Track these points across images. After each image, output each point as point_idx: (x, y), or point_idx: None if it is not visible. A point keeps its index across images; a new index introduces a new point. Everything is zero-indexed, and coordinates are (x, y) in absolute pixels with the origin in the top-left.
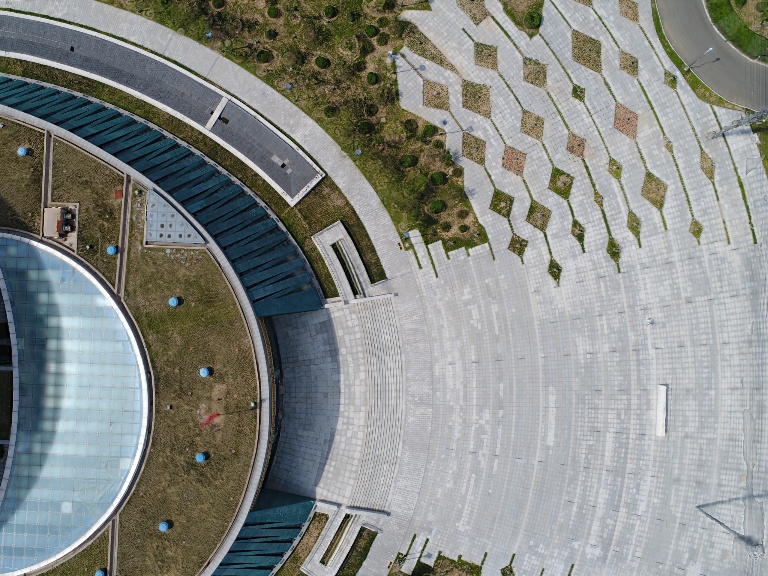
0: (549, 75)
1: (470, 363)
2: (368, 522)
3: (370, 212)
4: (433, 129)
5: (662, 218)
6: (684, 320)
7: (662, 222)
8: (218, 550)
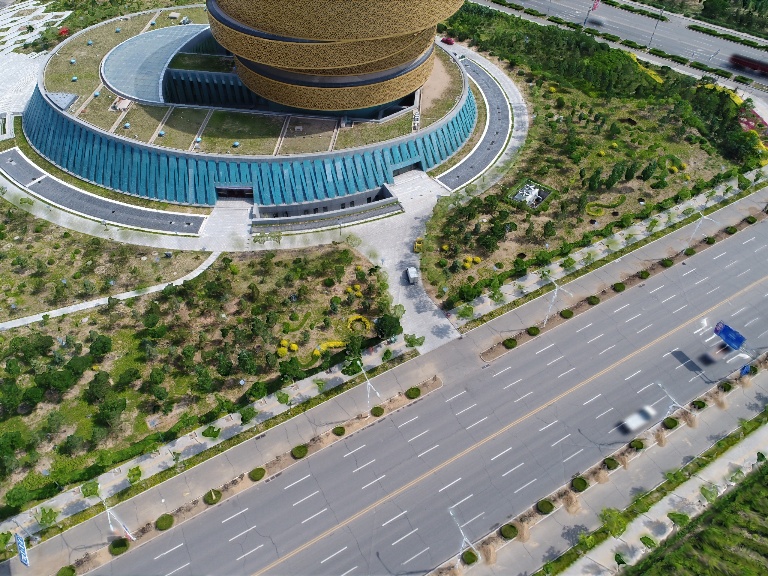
0: None
1: None
2: None
3: None
4: None
5: None
6: None
7: None
8: (99, 26)
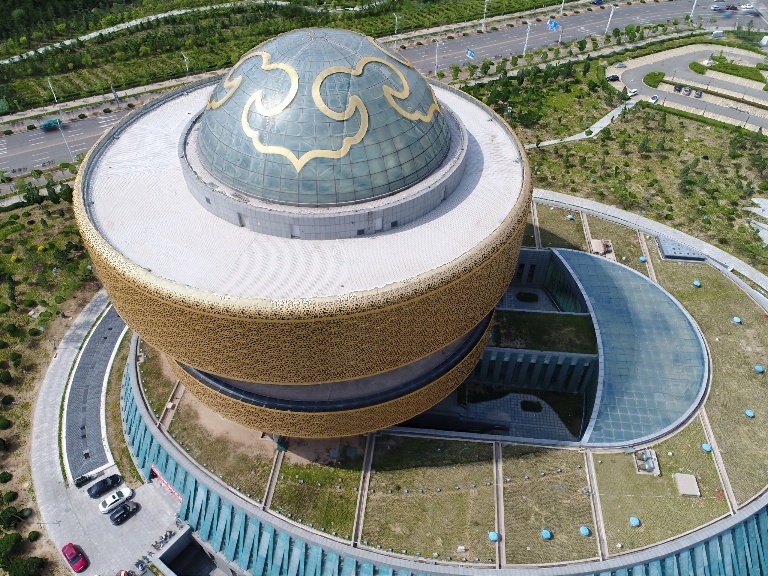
0: None
1: None
2: None
3: None
4: None
5: None
6: None
7: None
8: None
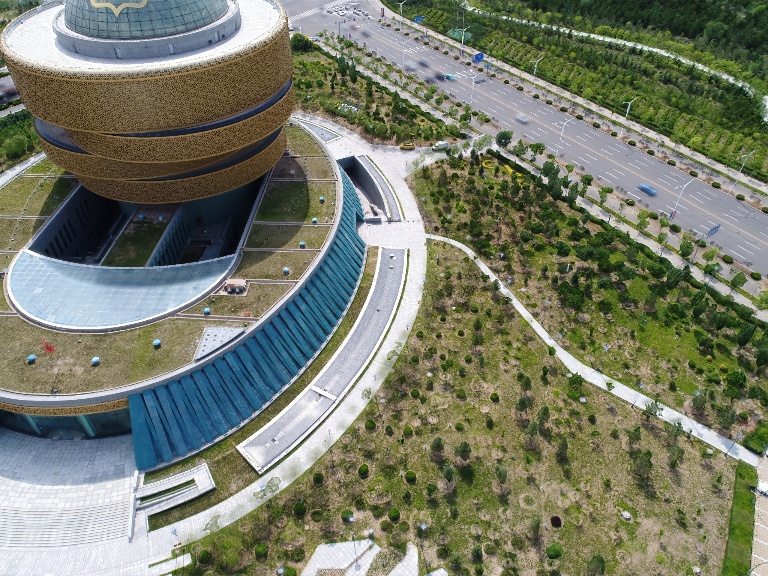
0: None
1: None
2: None
3: None
4: None
5: None
6: None
7: None
8: None
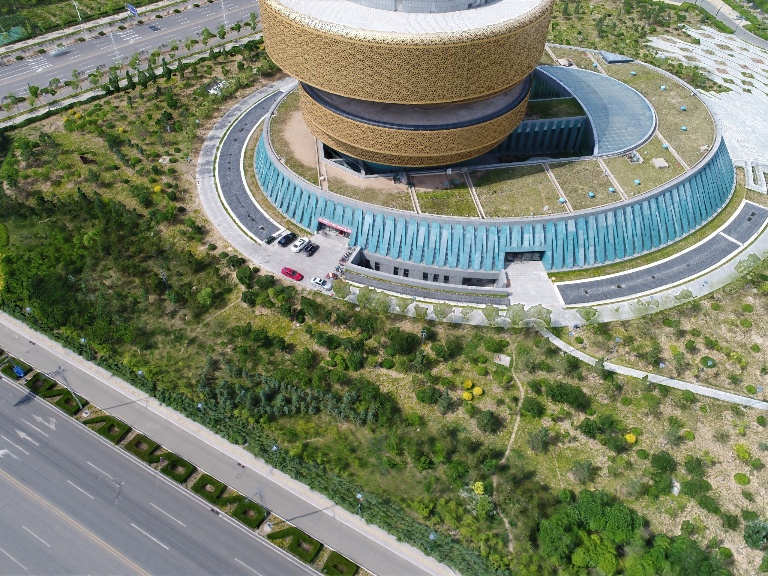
0: None
1: (761, 121)
2: (764, 171)
3: None
4: None
5: None
6: None
7: None
8: (716, 134)
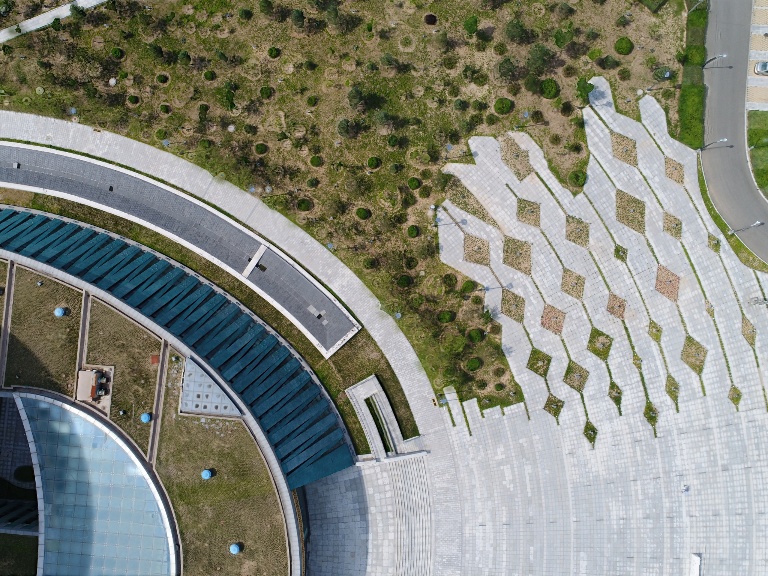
0: (592, 234)
1: (501, 525)
2: None
3: (405, 366)
4: (473, 286)
5: (701, 383)
6: (720, 488)
7: (701, 387)
8: None
